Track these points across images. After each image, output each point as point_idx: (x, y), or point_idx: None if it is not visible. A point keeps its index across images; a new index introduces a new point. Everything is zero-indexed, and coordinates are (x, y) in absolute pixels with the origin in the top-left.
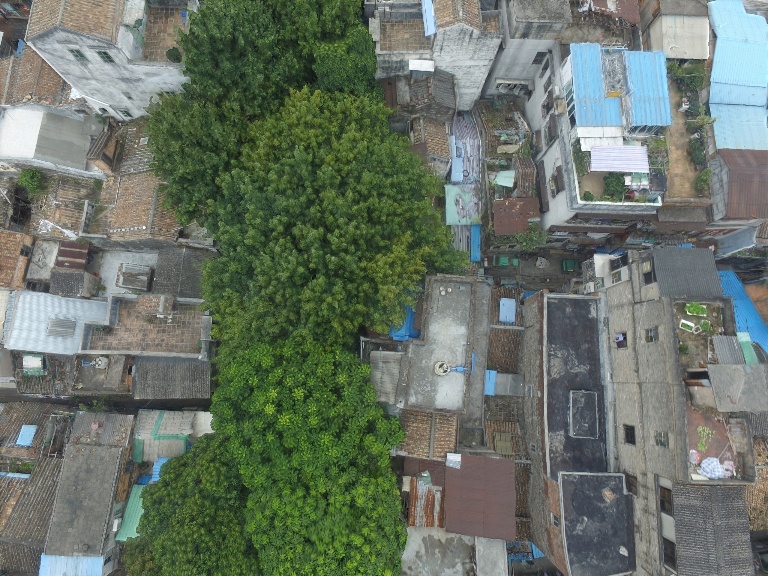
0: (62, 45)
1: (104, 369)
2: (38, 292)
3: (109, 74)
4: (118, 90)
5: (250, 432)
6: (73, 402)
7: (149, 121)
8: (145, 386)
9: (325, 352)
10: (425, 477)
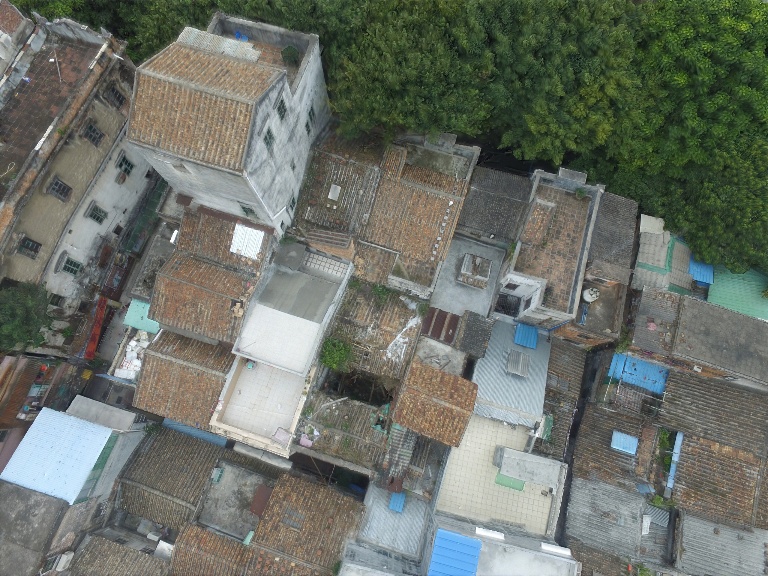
0: (260, 137)
1: (591, 303)
2: (472, 380)
3: (283, 143)
4: (288, 166)
5: (761, 62)
6: (579, 403)
7: (308, 184)
8: (616, 264)
9: (665, 8)
10: (763, 2)
